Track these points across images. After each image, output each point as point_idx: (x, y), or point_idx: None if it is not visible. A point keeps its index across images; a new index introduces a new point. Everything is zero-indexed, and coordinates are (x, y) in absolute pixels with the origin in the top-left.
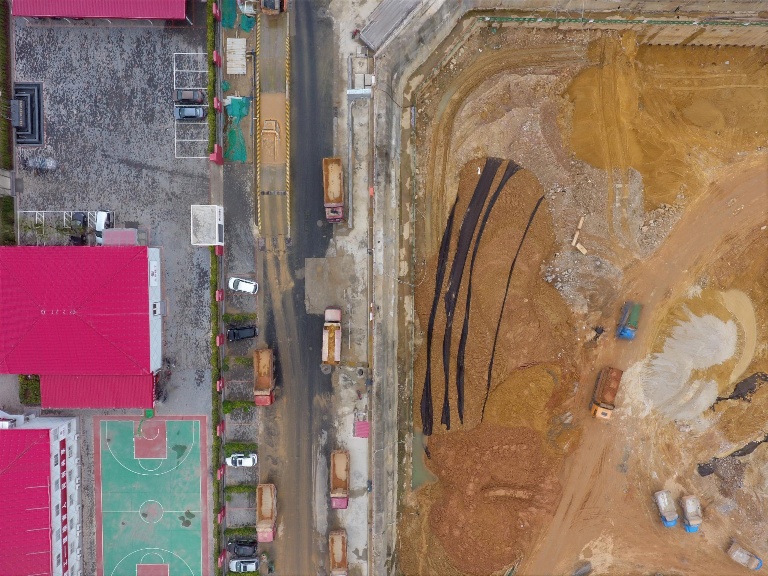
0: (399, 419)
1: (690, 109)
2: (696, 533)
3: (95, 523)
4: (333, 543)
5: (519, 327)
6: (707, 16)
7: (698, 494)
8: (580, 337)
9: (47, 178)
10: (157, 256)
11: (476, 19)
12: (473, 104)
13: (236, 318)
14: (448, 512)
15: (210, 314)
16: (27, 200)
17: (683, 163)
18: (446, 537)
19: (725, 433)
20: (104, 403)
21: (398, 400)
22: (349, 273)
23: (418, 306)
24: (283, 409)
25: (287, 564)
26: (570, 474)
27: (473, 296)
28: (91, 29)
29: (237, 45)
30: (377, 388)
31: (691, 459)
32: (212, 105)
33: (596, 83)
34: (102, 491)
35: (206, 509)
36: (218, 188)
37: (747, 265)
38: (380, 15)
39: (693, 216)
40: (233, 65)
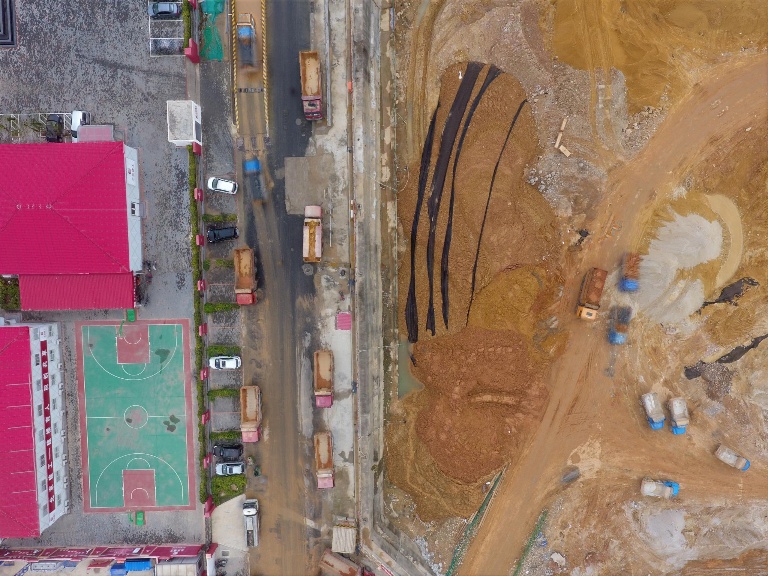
0: (384, 326)
1: (673, 13)
2: (684, 436)
3: (80, 429)
4: (319, 444)
5: (503, 230)
6: None
7: (685, 397)
8: (565, 241)
9: (21, 80)
10: (134, 156)
11: None
12: (453, 6)
13: (216, 219)
14: (435, 417)
15: (190, 216)
16: (1, 102)
17: (666, 64)
18: (433, 442)
19: (712, 336)
20: (84, 304)
21: (383, 307)
22: (329, 172)
23: (401, 213)
24: (266, 312)
25: (274, 468)
26: (557, 379)
27: (456, 201)
28: None
29: None
30: (360, 288)
31: (678, 362)
32: (186, 1)
33: None
34: (86, 397)
35: (191, 413)
36: (195, 87)
37: (732, 167)
38: None
39: (677, 118)
40: None
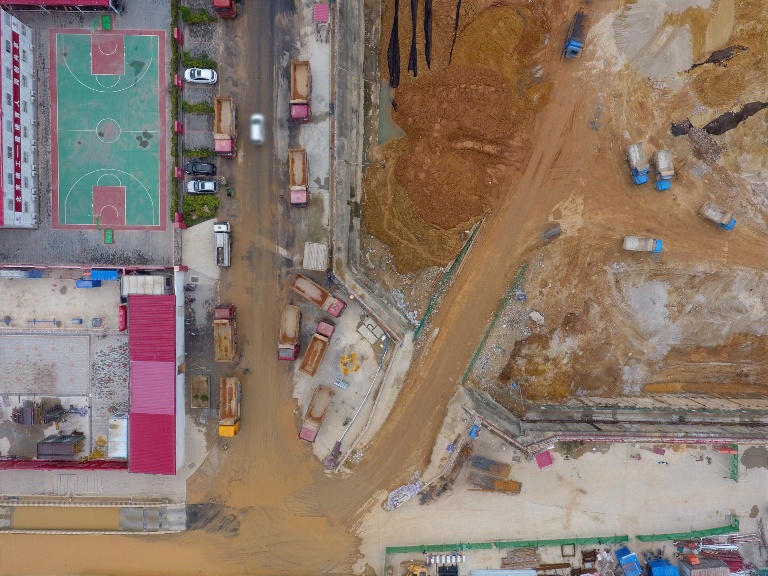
0: (365, 69)
1: None
2: (669, 196)
3: (51, 142)
4: (293, 163)
5: None
6: None
7: None
8: None
9: None
10: None
11: None
12: None
13: None
14: (414, 158)
15: None
16: None
17: None
18: (411, 183)
19: (700, 94)
20: None
21: (365, 49)
22: None
23: None
24: (244, 28)
25: (247, 192)
26: (540, 131)
27: None
28: None
29: None
30: (340, 5)
31: (664, 119)
32: None
33: None
34: (58, 108)
35: (164, 129)
36: None
37: None
38: None
39: None
40: None
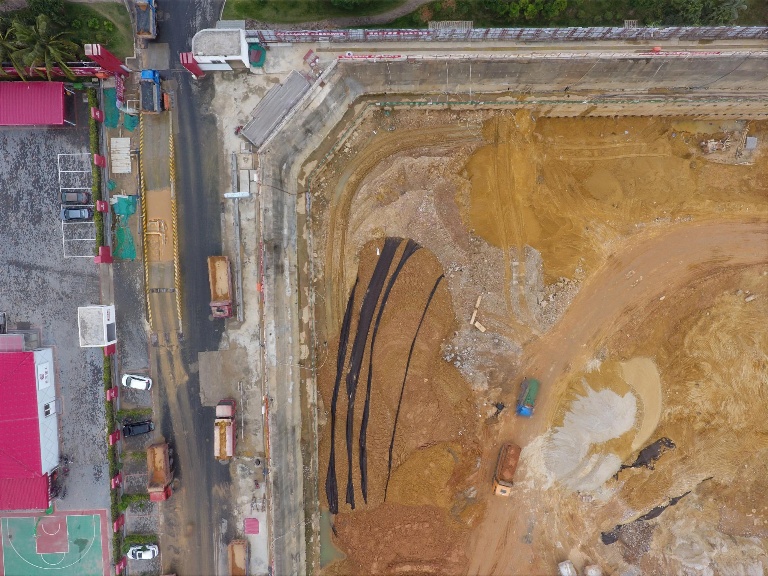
0: (305, 499)
1: (590, 180)
2: None
3: None
4: None
5: (419, 408)
6: (597, 94)
7: (603, 562)
8: (481, 414)
9: None
10: (49, 356)
11: (367, 104)
12: (369, 187)
13: (131, 414)
14: None
15: (106, 410)
16: None
17: (581, 237)
18: None
19: (628, 501)
20: None
21: (303, 481)
22: (242, 365)
23: (321, 387)
24: (183, 500)
25: None
26: (476, 547)
27: (374, 377)
28: None
29: (121, 144)
30: (274, 477)
31: (595, 528)
32: None
33: (491, 162)
34: None
35: None
36: (108, 286)
37: (647, 335)
38: (262, 111)
39: (591, 290)
40: (118, 164)
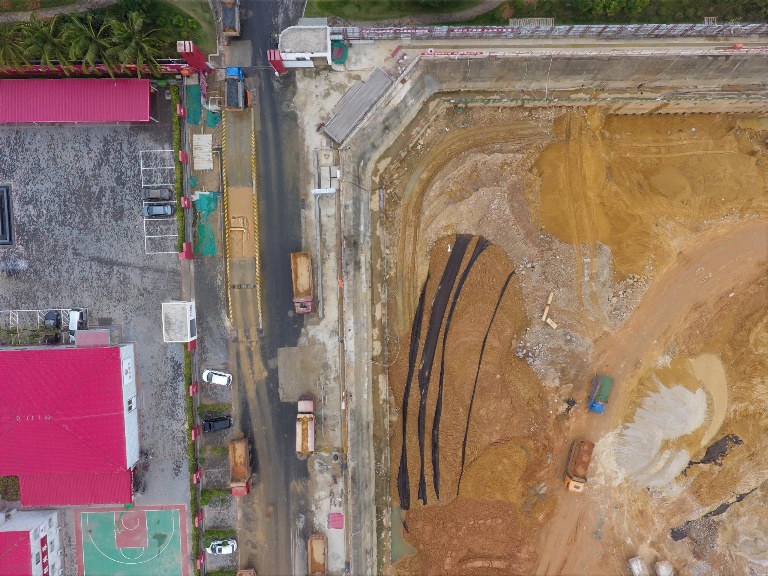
0: (377, 495)
1: (658, 177)
2: None
3: None
4: None
5: (492, 404)
6: (670, 91)
7: (672, 558)
8: (552, 410)
9: (19, 278)
10: (131, 352)
11: (441, 101)
12: (441, 183)
13: (211, 409)
14: None
15: (185, 405)
16: (0, 300)
17: (651, 234)
18: None
19: (697, 498)
20: (83, 499)
21: (375, 476)
22: (321, 361)
23: (392, 384)
24: (261, 495)
25: None
26: (546, 543)
27: (446, 373)
28: (57, 129)
29: (203, 141)
30: (352, 472)
31: (664, 524)
32: (180, 202)
33: (562, 159)
34: None
35: None
36: (189, 282)
37: (716, 332)
38: (344, 108)
39: (661, 286)
40: (200, 161)
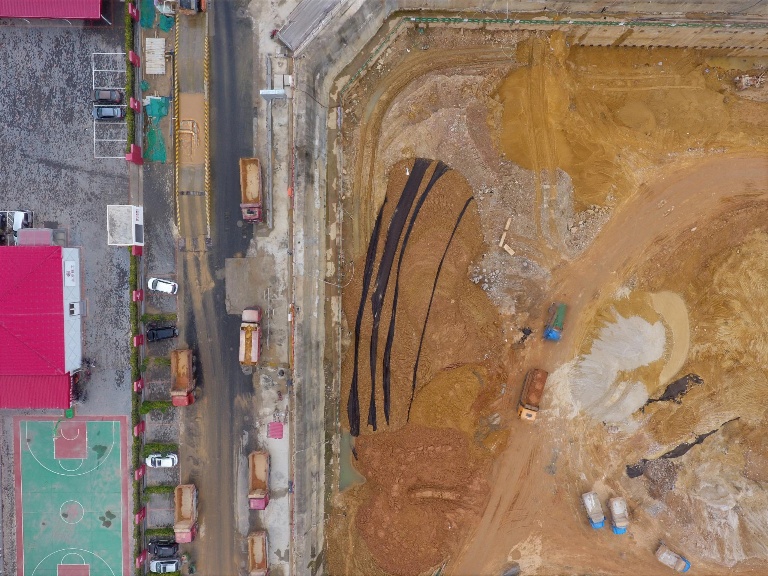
0: (326, 420)
1: (623, 110)
2: (625, 535)
3: (15, 523)
4: (253, 544)
5: (445, 328)
6: (634, 17)
7: (627, 496)
8: (508, 338)
9: None
10: (75, 256)
11: (402, 19)
12: (400, 105)
13: (155, 318)
14: (374, 513)
15: (130, 314)
16: None
17: (613, 164)
18: (371, 538)
19: (654, 435)
20: (20, 403)
21: (325, 401)
22: (270, 274)
23: (346, 307)
24: (204, 410)
25: (209, 565)
26: (498, 475)
27: (400, 297)
28: (9, 29)
29: (156, 45)
30: (298, 389)
31: (620, 461)
32: None
33: (524, 84)
34: (22, 491)
35: (127, 509)
36: (138, 188)
37: (677, 266)
38: (298, 15)
39: (622, 217)
40: (152, 65)
